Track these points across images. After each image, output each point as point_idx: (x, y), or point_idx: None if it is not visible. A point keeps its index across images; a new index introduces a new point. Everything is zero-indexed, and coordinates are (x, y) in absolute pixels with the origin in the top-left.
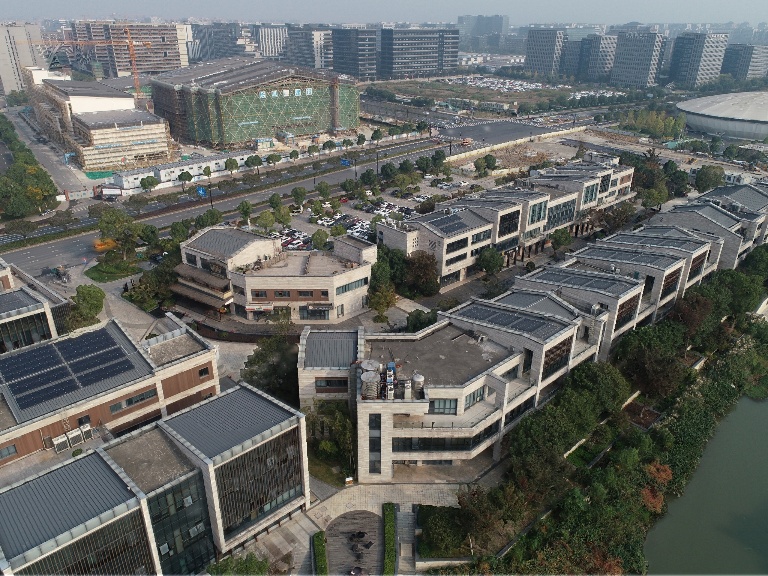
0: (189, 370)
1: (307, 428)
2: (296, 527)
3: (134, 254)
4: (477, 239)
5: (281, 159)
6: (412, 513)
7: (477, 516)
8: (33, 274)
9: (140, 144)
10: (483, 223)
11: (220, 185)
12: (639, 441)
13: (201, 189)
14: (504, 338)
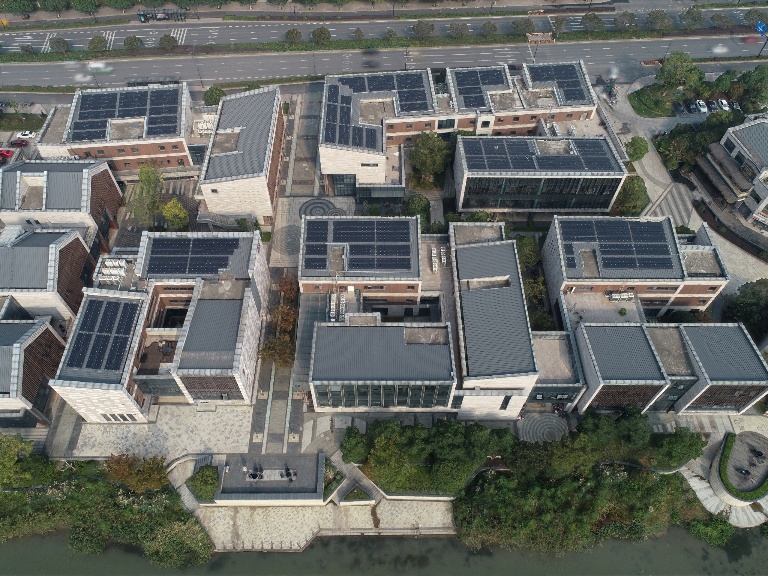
0: (705, 285)
1: None
2: (720, 420)
3: (673, 92)
4: None
5: None
6: None
7: None
8: (590, 80)
9: None
10: None
11: None
12: None
13: (763, 26)
14: None
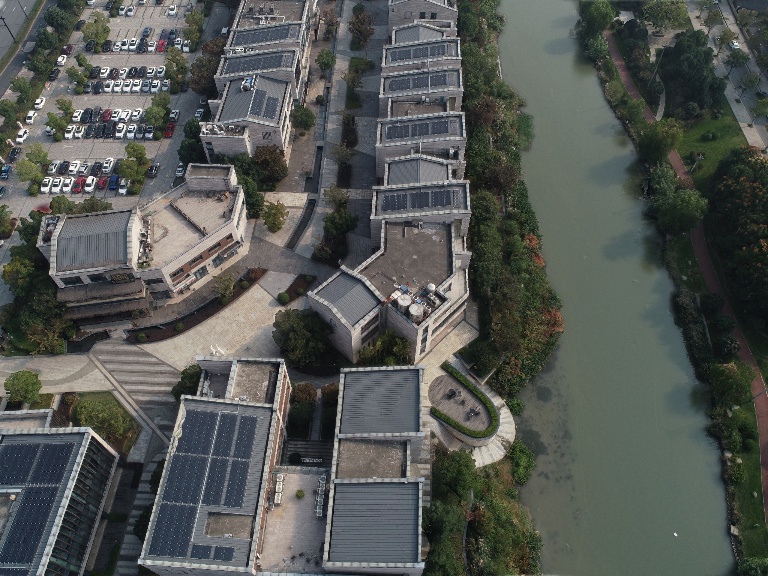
0: None
1: (356, 357)
2: None
3: None
4: None
5: None
6: (458, 359)
7: (512, 342)
8: None
9: None
10: (284, 87)
11: None
12: (511, 227)
13: None
14: (437, 218)
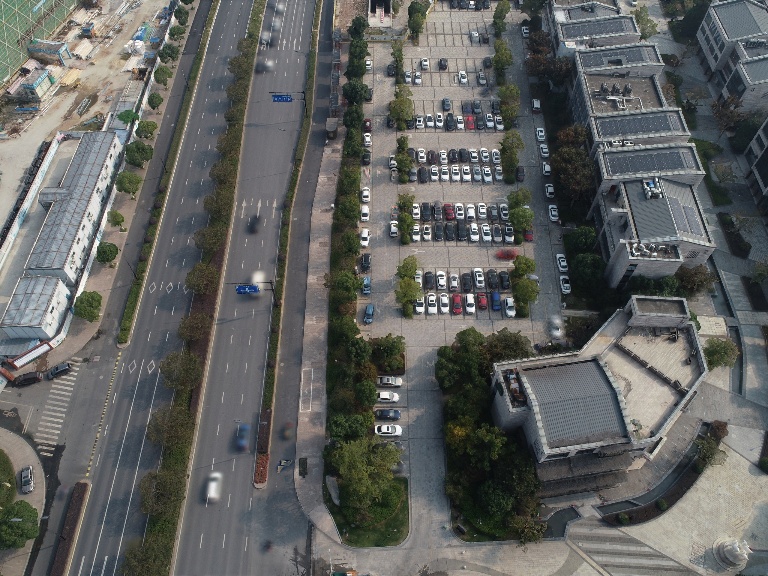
0: None
1: None
2: None
3: None
4: None
5: (138, 116)
6: None
7: None
8: None
9: None
10: (690, 192)
11: (211, 247)
12: None
13: (247, 287)
14: None
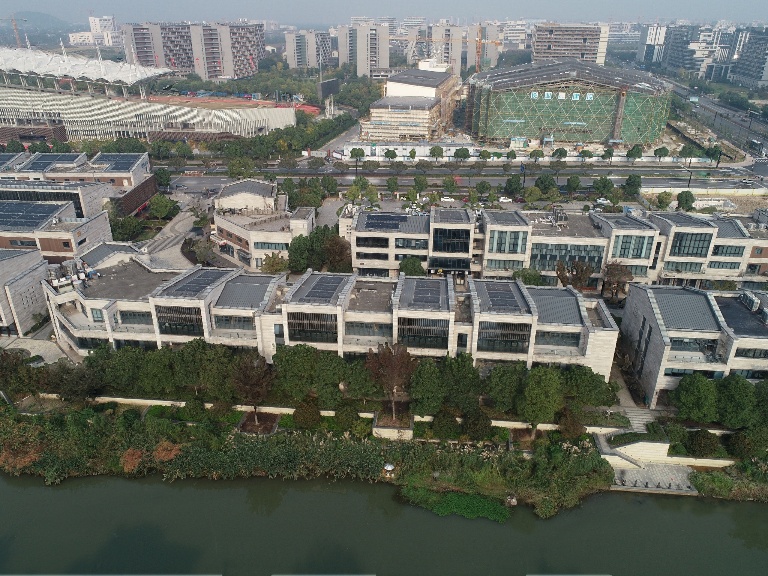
0: (56, 239)
1: None
2: (3, 341)
3: None
4: (405, 244)
5: (500, 157)
6: None
7: None
8: None
9: (405, 125)
10: (420, 231)
11: (391, 164)
12: None
13: None
14: None
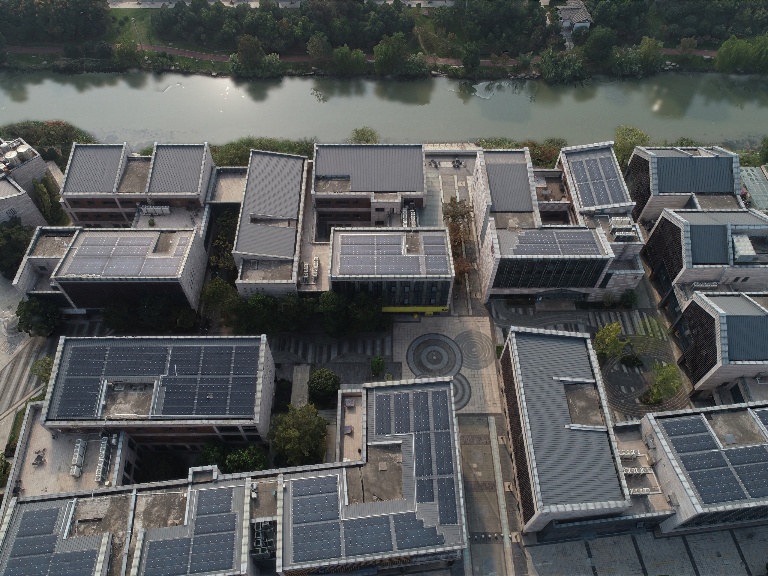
0: None
1: None
2: None
3: None
4: None
5: None
6: None
7: None
8: None
9: None
10: None
11: None
12: None
13: None
14: None
